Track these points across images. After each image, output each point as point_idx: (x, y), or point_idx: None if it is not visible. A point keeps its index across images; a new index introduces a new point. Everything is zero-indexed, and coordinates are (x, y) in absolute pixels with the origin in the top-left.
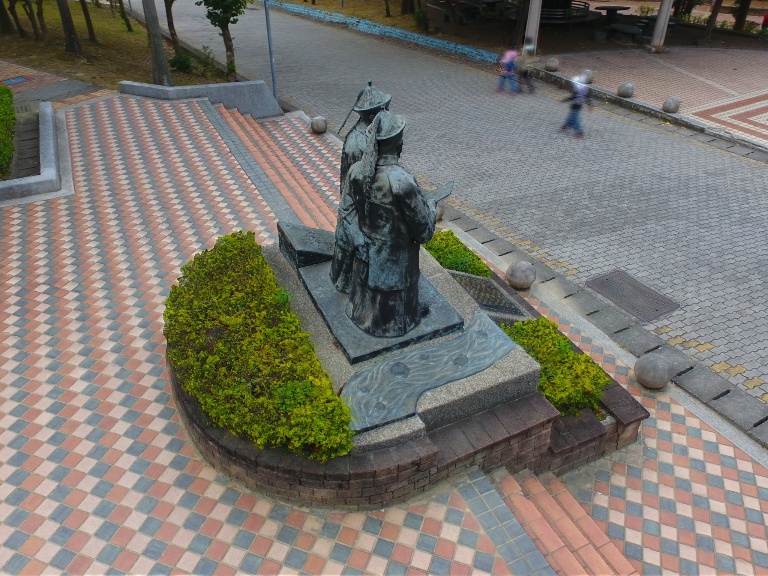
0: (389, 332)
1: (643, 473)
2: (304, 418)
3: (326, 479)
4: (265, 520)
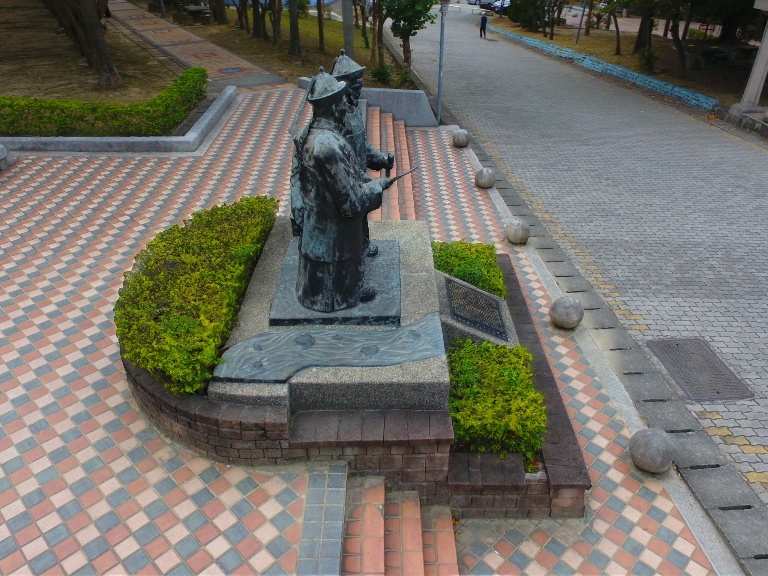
0: (317, 305)
1: (565, 553)
2: (167, 346)
3: (178, 413)
4: (132, 436)
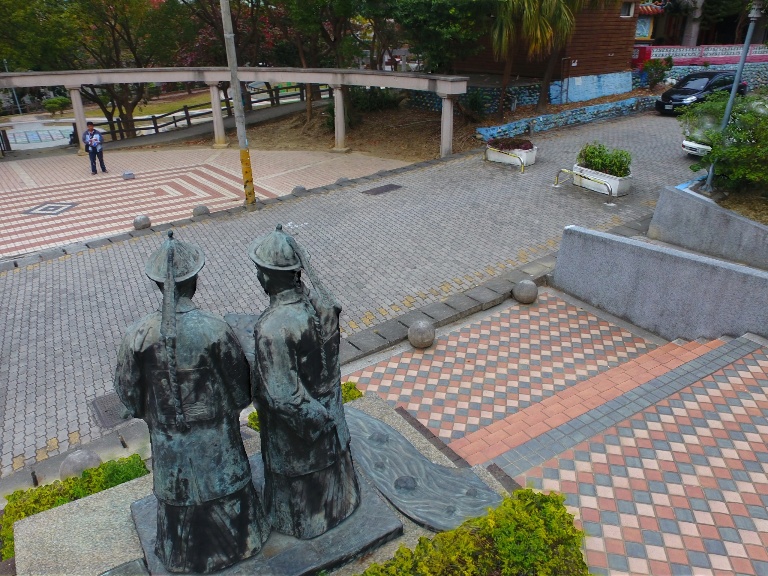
0: (358, 484)
1: None
2: (554, 523)
3: None
4: None
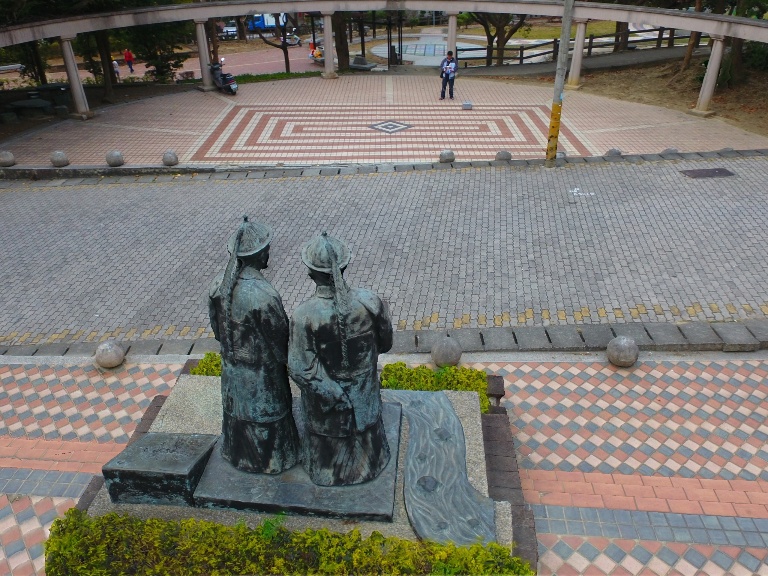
0: (383, 463)
1: (524, 420)
2: None
3: None
4: None
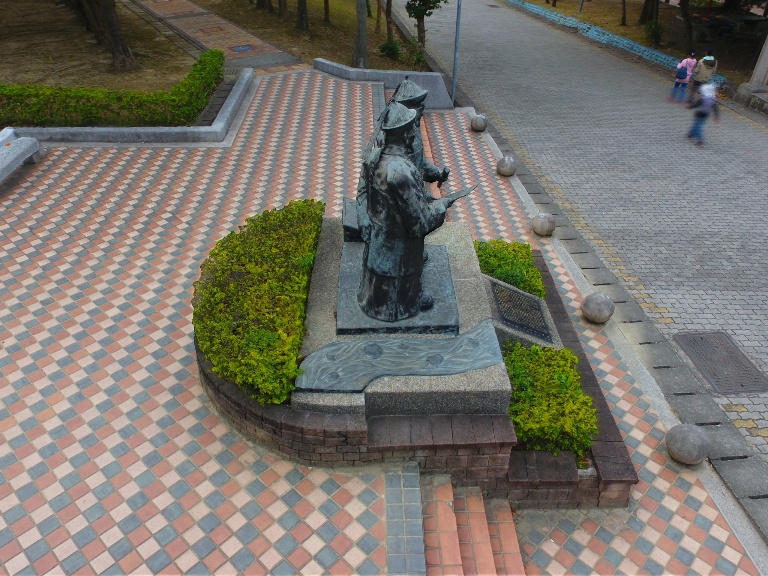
0: (381, 315)
1: (614, 540)
2: (253, 361)
3: (264, 421)
4: (216, 440)
